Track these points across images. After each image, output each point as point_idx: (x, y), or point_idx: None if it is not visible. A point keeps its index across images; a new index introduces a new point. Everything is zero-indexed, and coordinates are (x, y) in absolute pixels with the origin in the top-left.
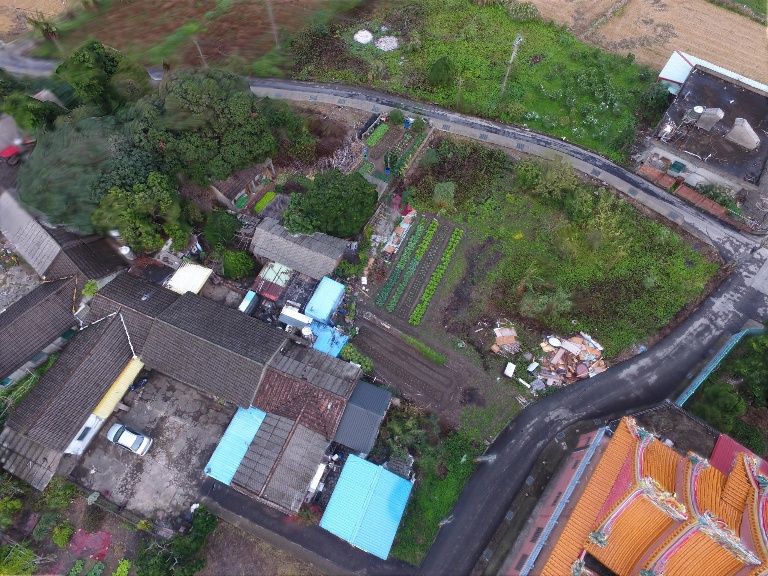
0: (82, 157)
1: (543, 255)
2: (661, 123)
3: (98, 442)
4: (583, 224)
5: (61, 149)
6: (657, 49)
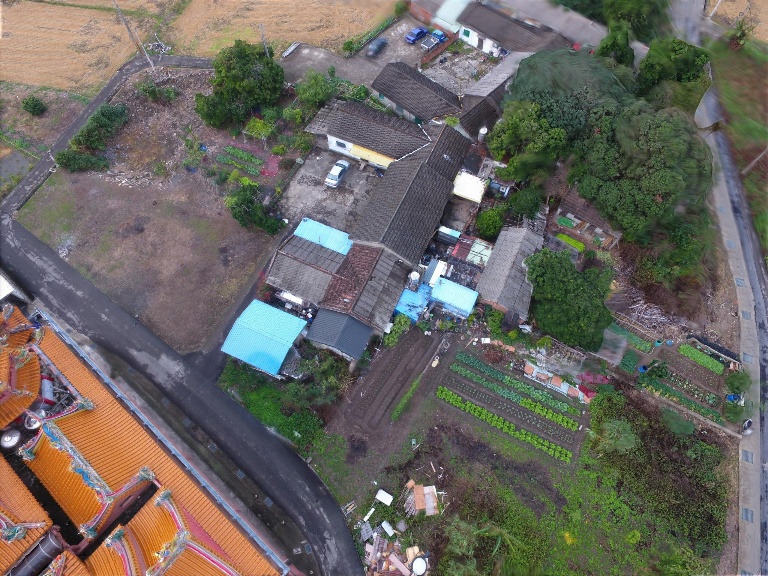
0: (561, 75)
1: None
2: None
3: (338, 157)
4: None
5: (569, 62)
6: None
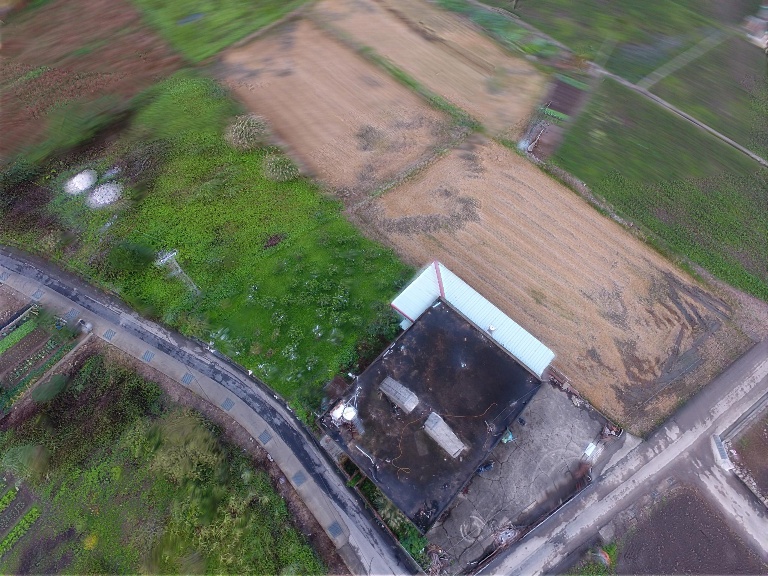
0: None
1: (125, 575)
2: (344, 393)
3: None
4: (194, 534)
5: None
6: (443, 238)
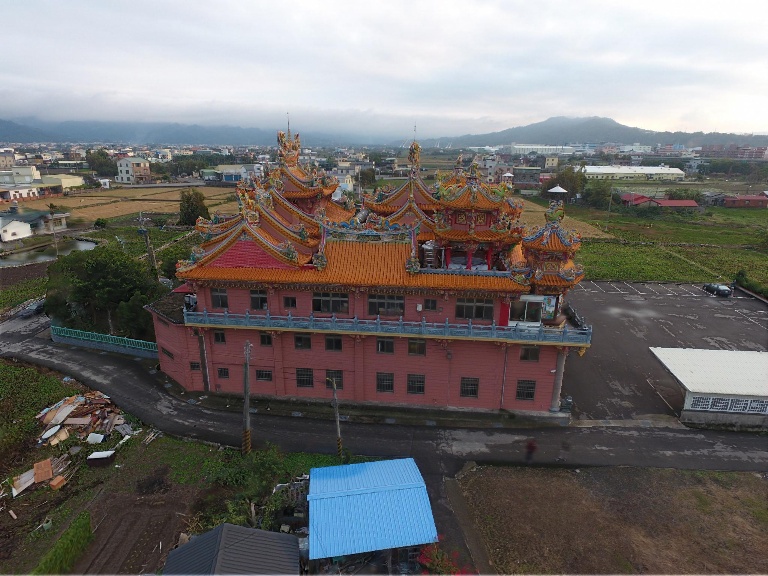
0: None
1: None
2: None
3: None
4: None
5: None
6: None
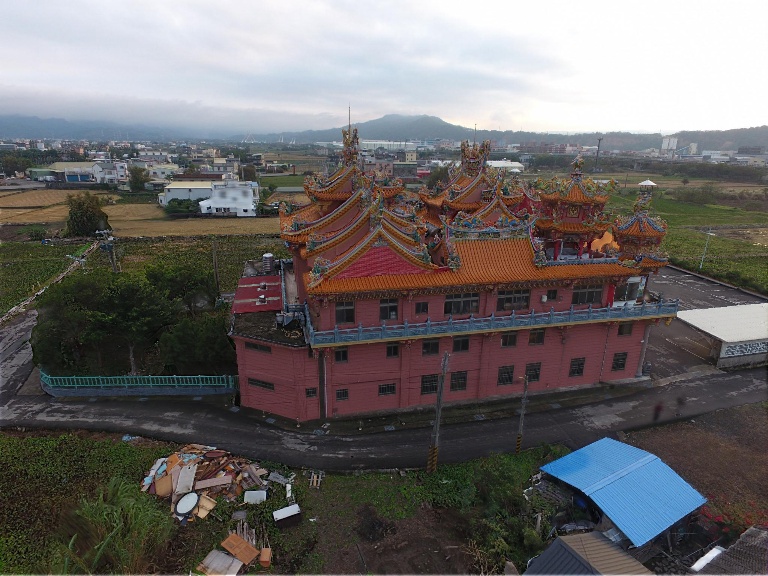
0: None
1: None
2: None
3: None
4: None
5: None
6: None
